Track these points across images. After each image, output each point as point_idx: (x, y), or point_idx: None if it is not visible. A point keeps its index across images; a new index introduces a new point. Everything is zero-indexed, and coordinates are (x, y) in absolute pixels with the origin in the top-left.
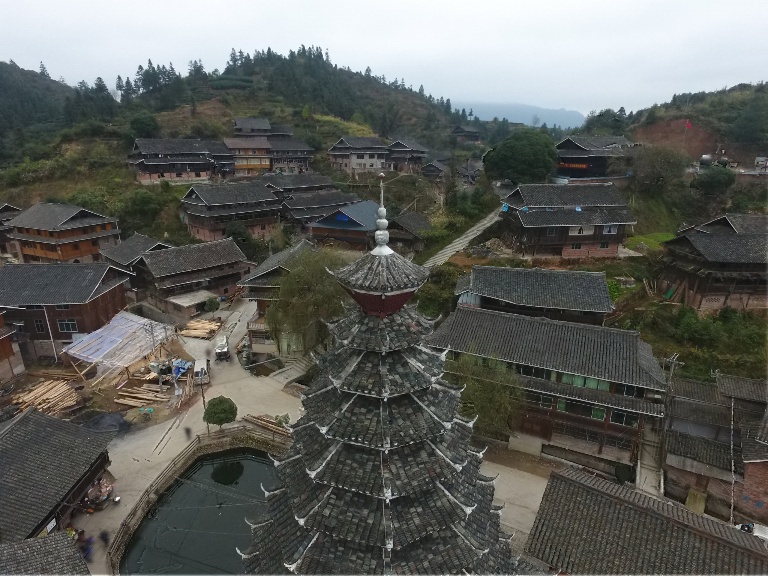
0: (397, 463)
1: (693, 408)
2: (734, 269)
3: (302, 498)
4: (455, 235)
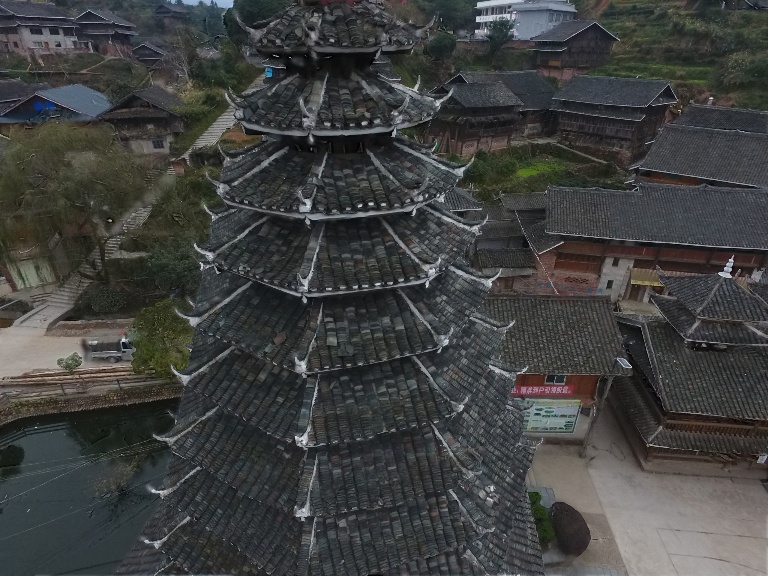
0: (414, 238)
1: (489, 228)
2: (482, 114)
3: (278, 342)
4: (218, 111)
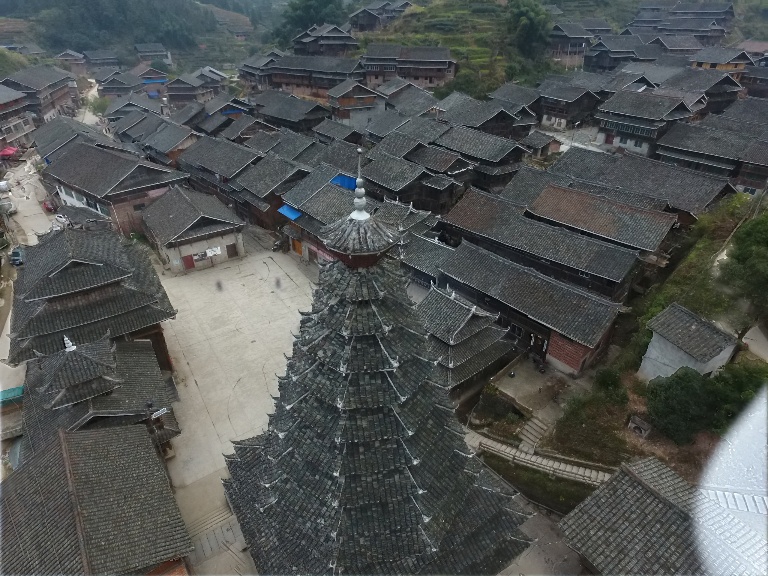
0: None
1: None
2: None
3: None
4: None
